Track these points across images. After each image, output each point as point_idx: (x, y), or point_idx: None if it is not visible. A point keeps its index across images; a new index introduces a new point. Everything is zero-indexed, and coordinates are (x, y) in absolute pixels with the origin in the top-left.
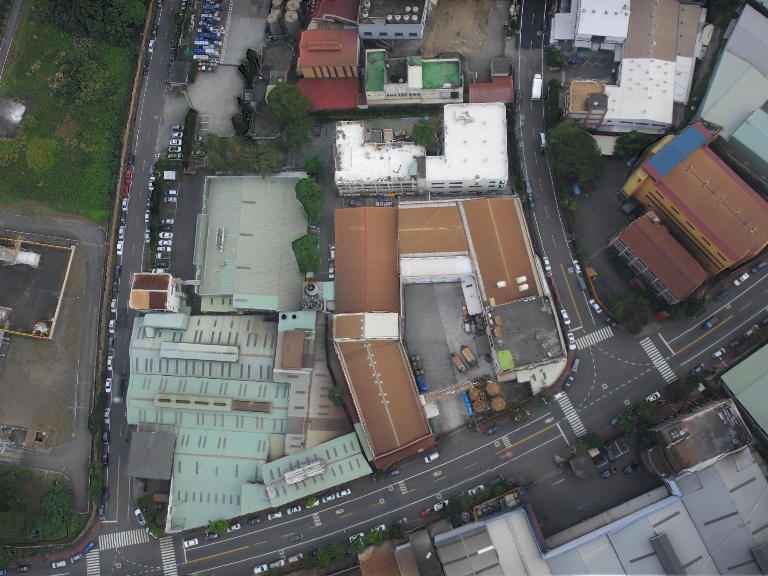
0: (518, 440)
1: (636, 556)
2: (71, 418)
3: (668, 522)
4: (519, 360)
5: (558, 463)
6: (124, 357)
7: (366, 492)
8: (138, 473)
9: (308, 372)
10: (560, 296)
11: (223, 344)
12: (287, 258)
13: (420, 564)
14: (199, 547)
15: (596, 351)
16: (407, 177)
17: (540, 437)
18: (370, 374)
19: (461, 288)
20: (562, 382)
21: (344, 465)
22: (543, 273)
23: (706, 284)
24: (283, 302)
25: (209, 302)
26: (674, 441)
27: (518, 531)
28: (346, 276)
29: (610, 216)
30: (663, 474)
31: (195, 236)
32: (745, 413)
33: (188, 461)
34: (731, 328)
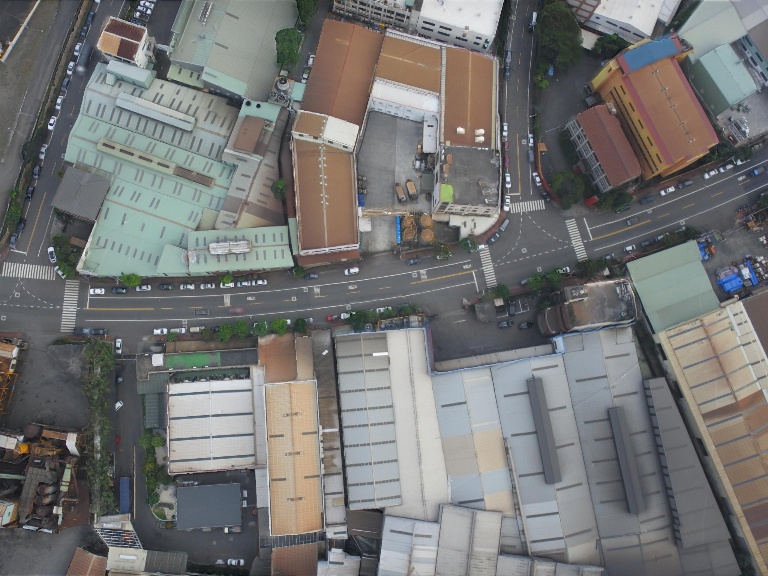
0: (434, 276)
1: (510, 392)
2: (4, 144)
3: (546, 370)
4: (458, 199)
5: (464, 305)
6: (75, 101)
7: (281, 287)
8: (64, 205)
9: (258, 159)
10: (509, 161)
11: (181, 112)
12: (266, 52)
13: (315, 357)
14: (104, 298)
15: (526, 218)
16: (403, 7)
17: (455, 279)
18: (317, 175)
19: (422, 128)
20: (488, 236)
21: (269, 252)
22: (500, 136)
23: (638, 183)
24: (251, 91)
25: (177, 71)
26: (573, 298)
27: (414, 345)
28: (319, 82)
29: (573, 105)
30: (554, 331)
31: (180, 5)
32: (638, 298)
33: (117, 210)
34: (646, 230)
